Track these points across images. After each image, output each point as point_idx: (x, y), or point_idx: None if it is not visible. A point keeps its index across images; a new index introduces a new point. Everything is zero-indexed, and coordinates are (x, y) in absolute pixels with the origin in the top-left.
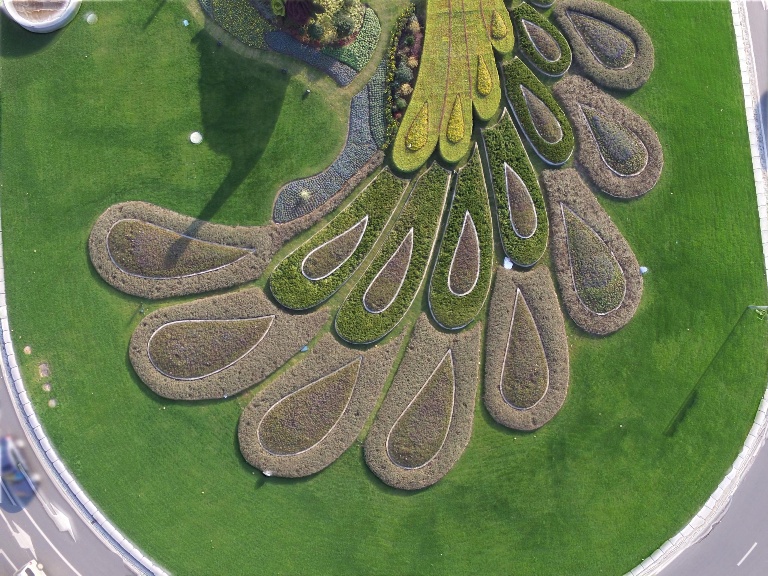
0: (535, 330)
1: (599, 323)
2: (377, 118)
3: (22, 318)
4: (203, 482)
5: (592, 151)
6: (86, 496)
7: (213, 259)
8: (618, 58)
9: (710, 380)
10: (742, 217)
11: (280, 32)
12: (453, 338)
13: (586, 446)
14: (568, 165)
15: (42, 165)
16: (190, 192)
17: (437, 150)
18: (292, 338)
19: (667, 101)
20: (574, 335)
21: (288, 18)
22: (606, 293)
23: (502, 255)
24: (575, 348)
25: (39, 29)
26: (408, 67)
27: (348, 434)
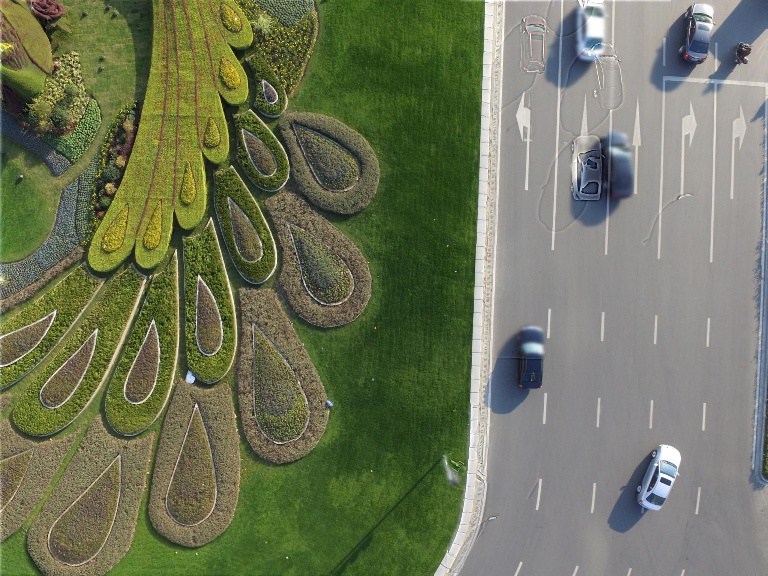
0: (207, 449)
1: (274, 452)
2: (82, 213)
3: None
4: None
5: (293, 274)
6: None
7: None
8: (337, 180)
9: (390, 526)
10: (452, 362)
11: (4, 114)
12: (124, 444)
13: (248, 572)
14: (268, 285)
15: None
16: None
17: (133, 254)
18: None
19: (387, 230)
20: (250, 459)
21: None
22: (284, 423)
23: (186, 368)
24: (249, 472)
25: None
26: (114, 166)
27: (12, 521)
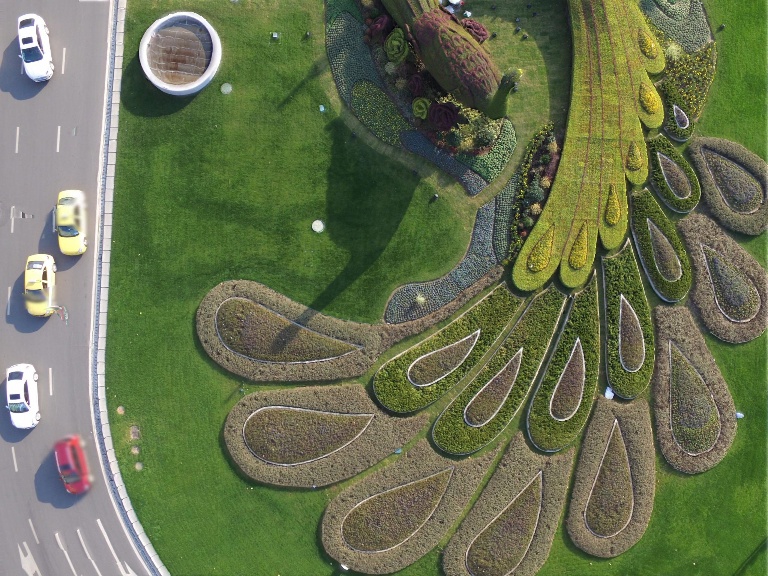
0: (626, 462)
1: (689, 463)
2: (501, 232)
3: (119, 377)
4: (280, 565)
5: (707, 293)
6: (161, 560)
7: (320, 350)
8: (746, 203)
9: None
10: None
11: (416, 132)
12: (546, 460)
13: None
14: (681, 303)
15: (158, 228)
16: (305, 279)
17: (557, 273)
18: (389, 440)
19: None
20: (663, 471)
21: (427, 121)
22: (701, 435)
23: (605, 384)
24: (662, 484)
25: (172, 91)
26: (540, 187)
27: (430, 540)
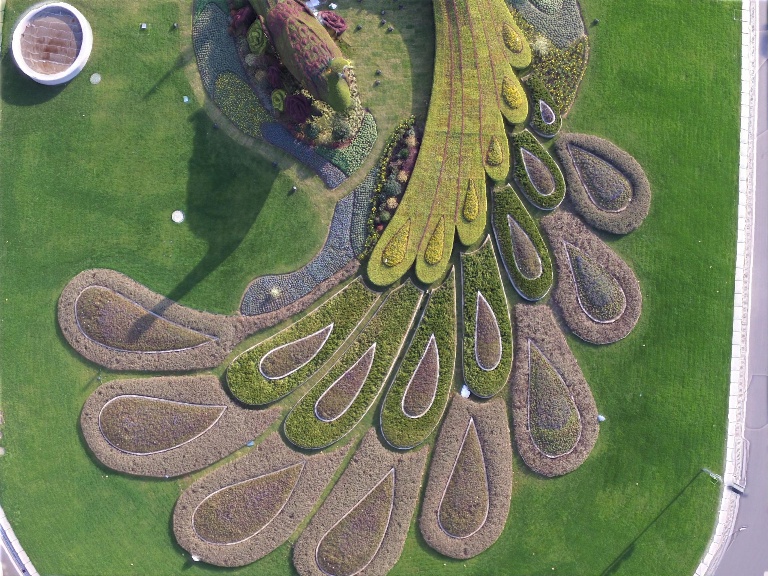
0: (482, 462)
1: (547, 465)
2: (358, 226)
3: None
4: (134, 554)
5: (569, 292)
6: (21, 545)
7: (175, 340)
8: (612, 201)
9: (651, 537)
10: (712, 378)
11: (276, 124)
12: (398, 458)
13: None
14: (543, 302)
15: (25, 216)
16: (163, 269)
17: (413, 268)
18: (240, 432)
19: (656, 251)
20: (521, 472)
21: (285, 113)
22: (559, 437)
23: (461, 382)
24: (519, 485)
25: (42, 81)
26: (397, 181)
27: (280, 534)
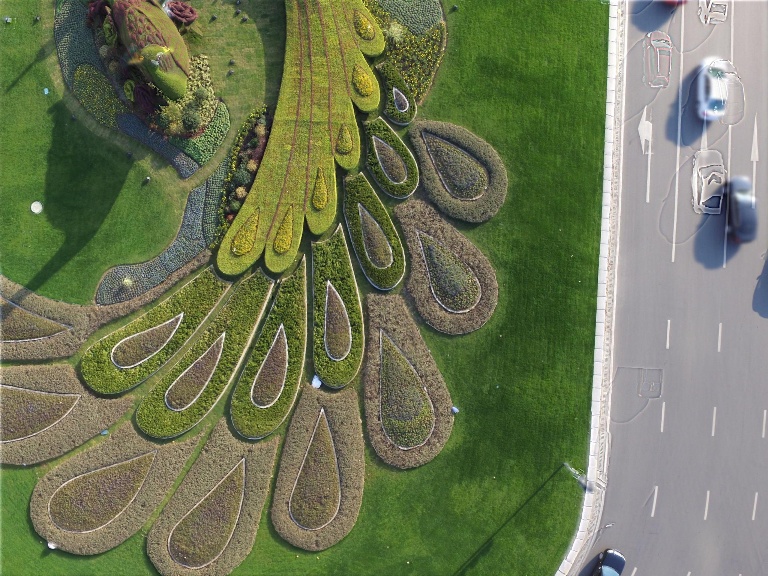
0: (333, 453)
1: (400, 457)
2: (210, 216)
3: None
4: None
5: (422, 281)
6: None
7: (32, 330)
8: (466, 189)
9: (510, 532)
10: (574, 370)
11: (131, 115)
12: (248, 448)
13: None
14: (396, 291)
15: None
16: (22, 260)
17: (262, 258)
18: (93, 420)
19: (513, 239)
20: (373, 464)
21: (137, 103)
22: (411, 428)
23: (312, 372)
24: (372, 477)
25: None
26: (245, 170)
27: (132, 523)
